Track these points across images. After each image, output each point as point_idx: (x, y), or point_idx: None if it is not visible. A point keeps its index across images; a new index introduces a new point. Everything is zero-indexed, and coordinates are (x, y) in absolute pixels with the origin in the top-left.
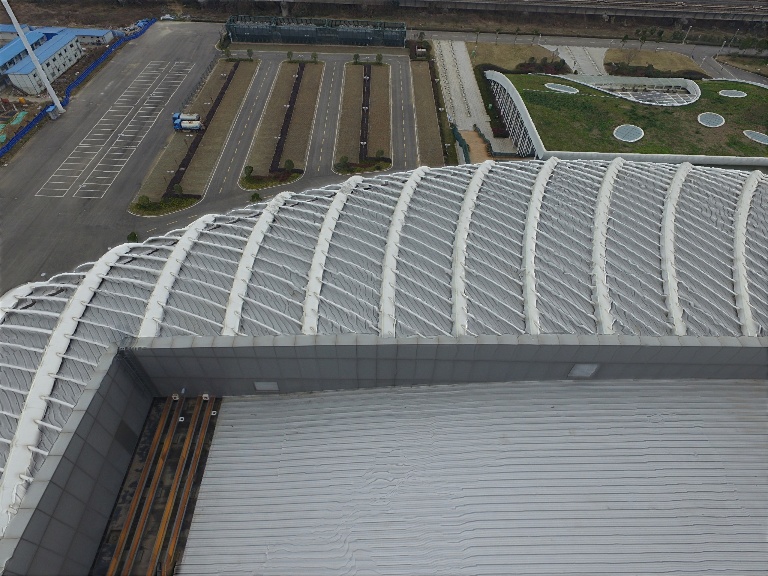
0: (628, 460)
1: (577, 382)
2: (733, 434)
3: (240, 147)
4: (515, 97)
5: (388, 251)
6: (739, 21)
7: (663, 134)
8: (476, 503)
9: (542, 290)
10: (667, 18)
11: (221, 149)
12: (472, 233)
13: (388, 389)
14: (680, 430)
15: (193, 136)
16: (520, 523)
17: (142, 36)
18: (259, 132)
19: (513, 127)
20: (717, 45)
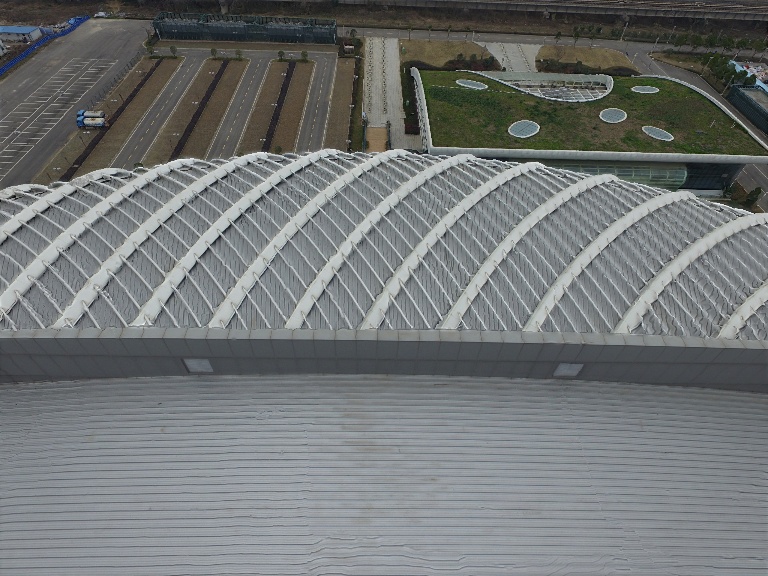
0: (201, 458)
1: (201, 378)
2: (339, 431)
3: (141, 144)
4: (420, 93)
5: (53, 243)
6: (684, 18)
7: (559, 130)
8: (22, 504)
9: (188, 283)
10: (612, 15)
11: (121, 146)
12: (162, 225)
13: (11, 385)
14: (281, 427)
15: (96, 133)
16: (51, 525)
17: (71, 33)
18: (164, 129)
19: (422, 124)
20: None
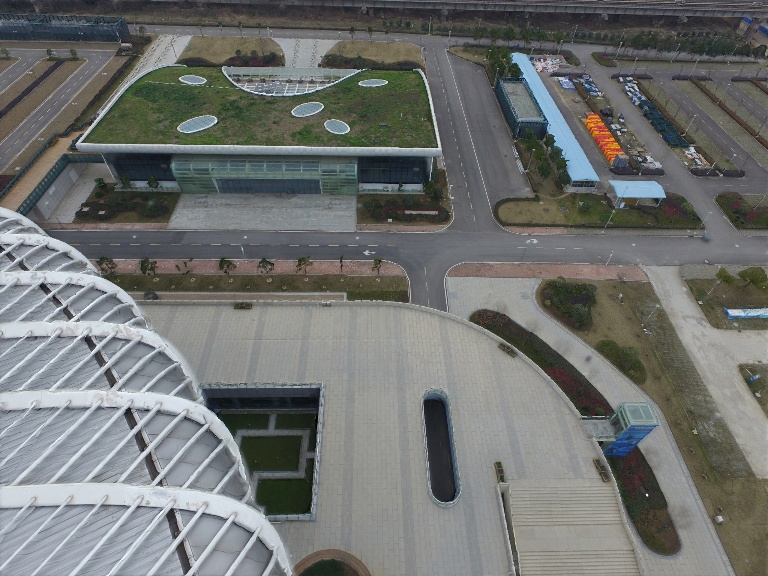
0: None
1: None
2: None
3: None
4: None
5: None
6: None
7: (235, 124)
8: None
9: None
10: None
11: None
12: None
13: None
14: None
15: None
16: None
17: None
18: None
19: None
20: (464, 36)
